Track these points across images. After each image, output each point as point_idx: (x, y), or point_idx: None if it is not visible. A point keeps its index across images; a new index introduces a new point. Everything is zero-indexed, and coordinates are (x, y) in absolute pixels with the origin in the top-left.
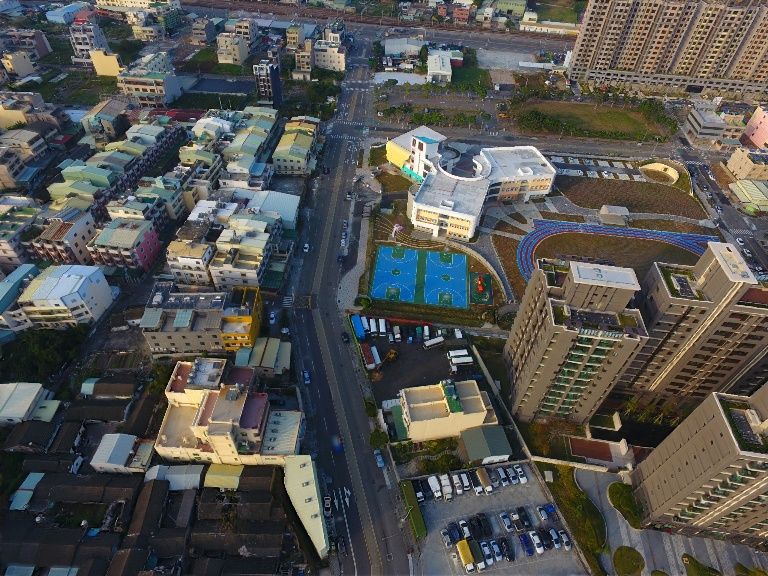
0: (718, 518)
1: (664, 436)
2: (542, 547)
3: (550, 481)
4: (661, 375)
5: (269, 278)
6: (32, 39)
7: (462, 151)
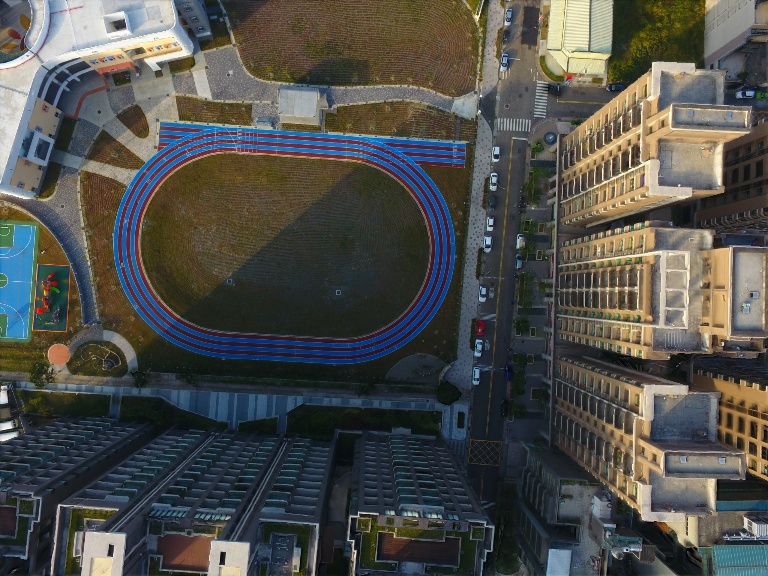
0: None
1: None
2: None
3: None
4: None
5: None
6: None
7: None
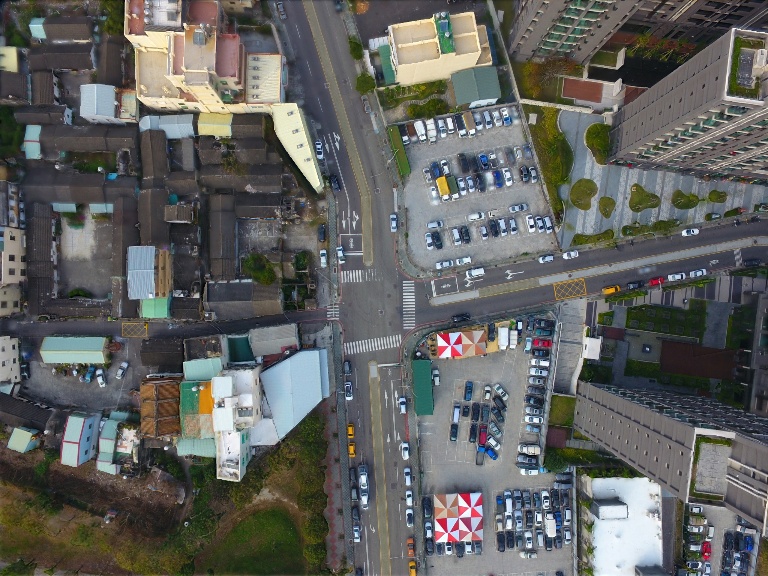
0: (678, 156)
1: (664, 75)
2: (511, 181)
3: (533, 123)
4: (691, 1)
5: None
6: None
7: None
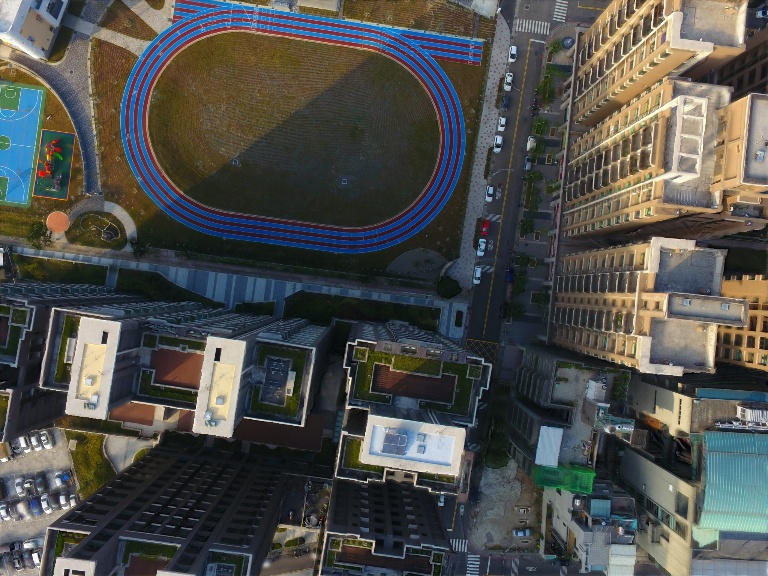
0: None
1: None
2: (50, 510)
3: (73, 450)
4: None
5: None
6: None
7: None
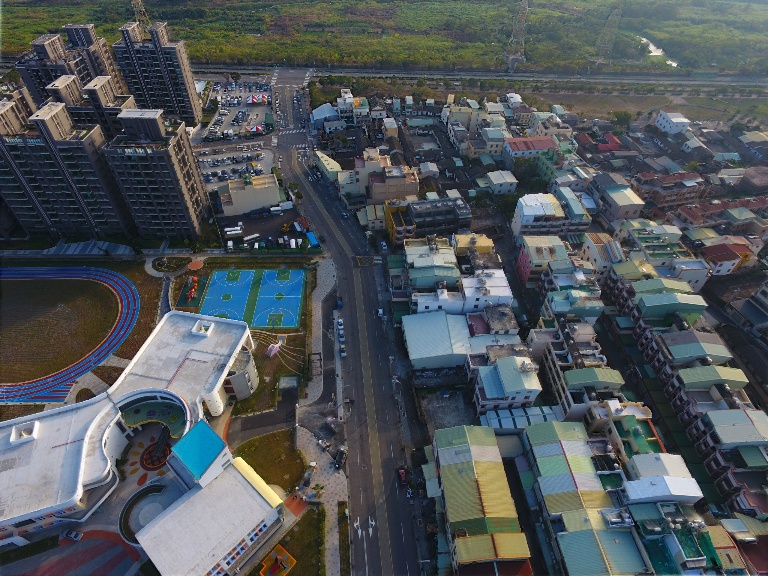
0: None
1: None
2: None
3: None
4: None
5: (399, 262)
6: None
7: None
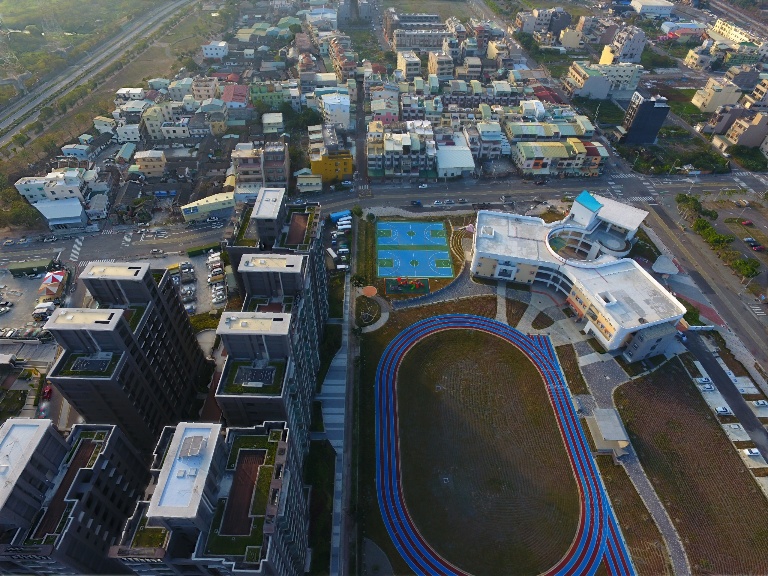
0: None
1: None
2: None
3: None
4: None
5: (377, 171)
6: (605, 29)
7: (654, 267)
